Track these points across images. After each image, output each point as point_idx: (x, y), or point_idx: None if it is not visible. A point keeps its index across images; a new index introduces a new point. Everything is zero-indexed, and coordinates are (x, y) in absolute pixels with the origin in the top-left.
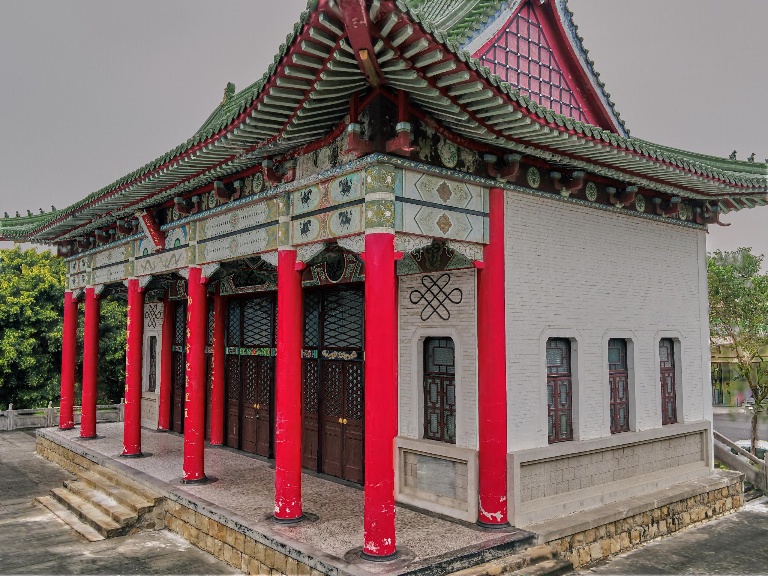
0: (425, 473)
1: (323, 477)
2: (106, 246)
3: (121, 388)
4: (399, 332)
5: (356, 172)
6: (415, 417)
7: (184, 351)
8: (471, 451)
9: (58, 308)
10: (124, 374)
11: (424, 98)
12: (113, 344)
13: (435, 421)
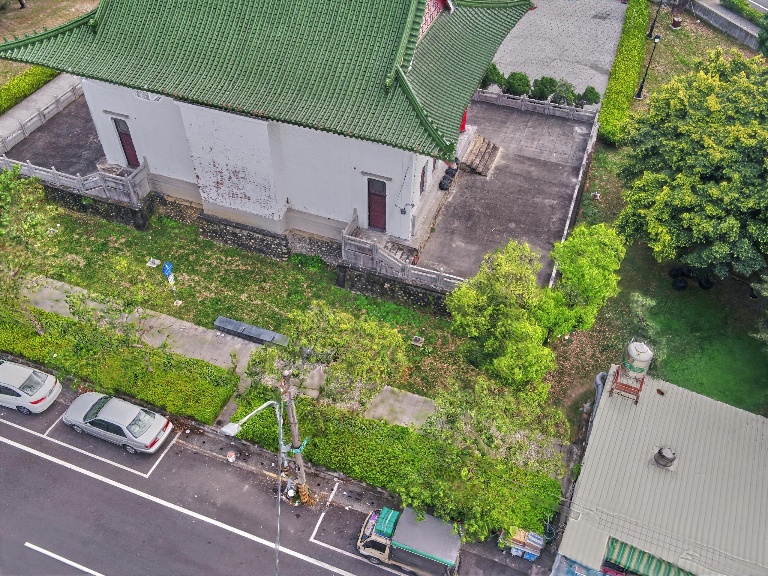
0: None
1: None
2: None
3: None
4: None
5: None
6: None
7: None
8: None
9: None
10: None
11: None
12: None
13: None
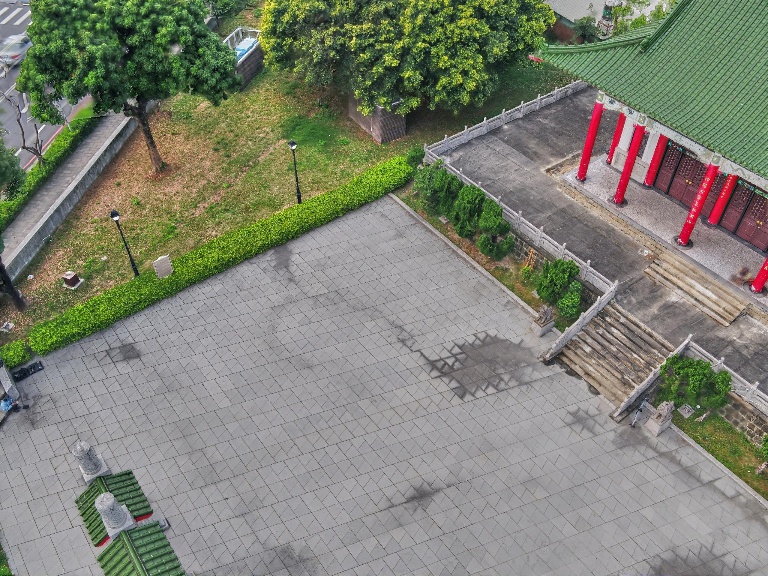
0: None
1: None
2: None
3: (510, 62)
4: None
5: None
6: None
7: (685, 153)
8: None
9: (482, 15)
10: (522, 59)
11: None
12: (516, 37)
13: None
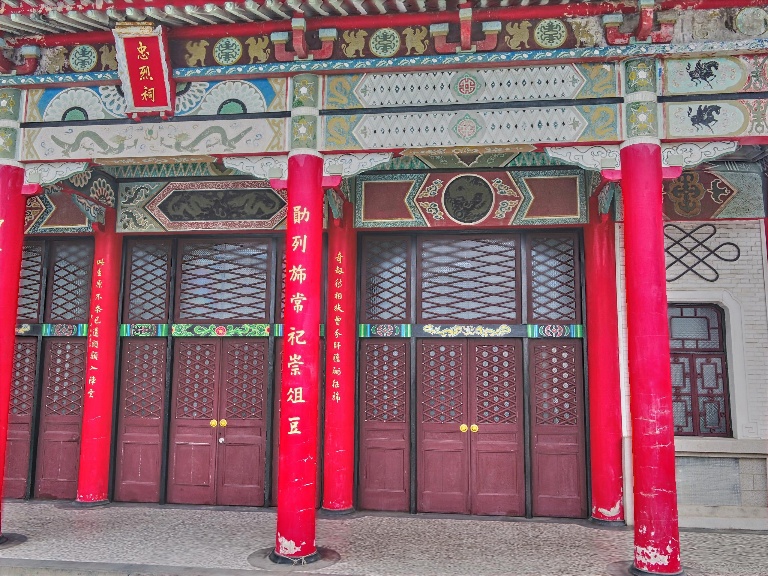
0: (682, 480)
1: (442, 517)
2: None
3: None
4: (619, 296)
5: None
6: None
7: None
8: None
9: None
10: None
11: None
12: None
13: (682, 411)
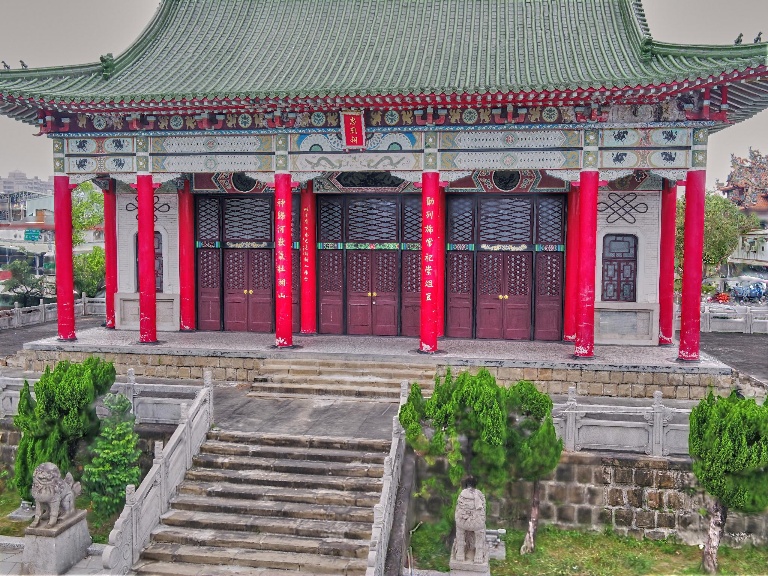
0: (608, 322)
1: (489, 340)
2: (212, 132)
3: None
4: None
5: (683, 128)
6: (599, 287)
7: (225, 247)
8: (655, 304)
9: None
10: None
11: (740, 93)
12: None
13: (612, 289)
